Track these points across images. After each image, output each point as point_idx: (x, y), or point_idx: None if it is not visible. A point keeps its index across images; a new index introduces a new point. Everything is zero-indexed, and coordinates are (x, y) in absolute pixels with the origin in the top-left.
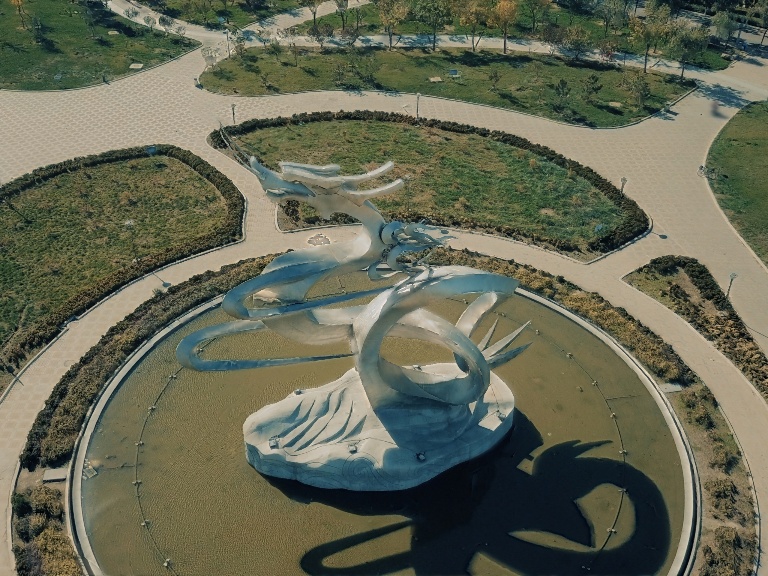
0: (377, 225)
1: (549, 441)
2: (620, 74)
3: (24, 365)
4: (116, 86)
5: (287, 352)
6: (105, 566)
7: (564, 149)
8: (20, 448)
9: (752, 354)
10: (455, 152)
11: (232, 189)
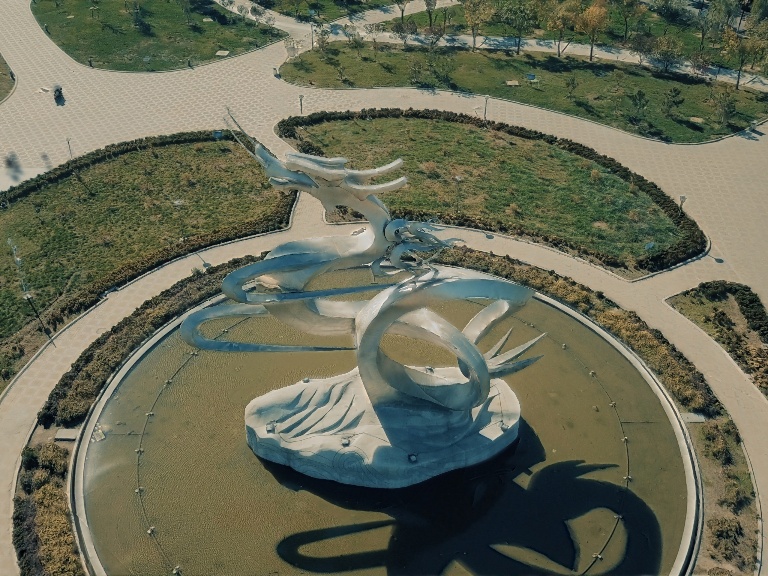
0: (382, 221)
1: (552, 458)
2: (709, 89)
3: (60, 328)
4: (199, 71)
5: (309, 341)
6: (94, 526)
7: (632, 162)
8: (41, 406)
9: None
10: (517, 157)
11: None
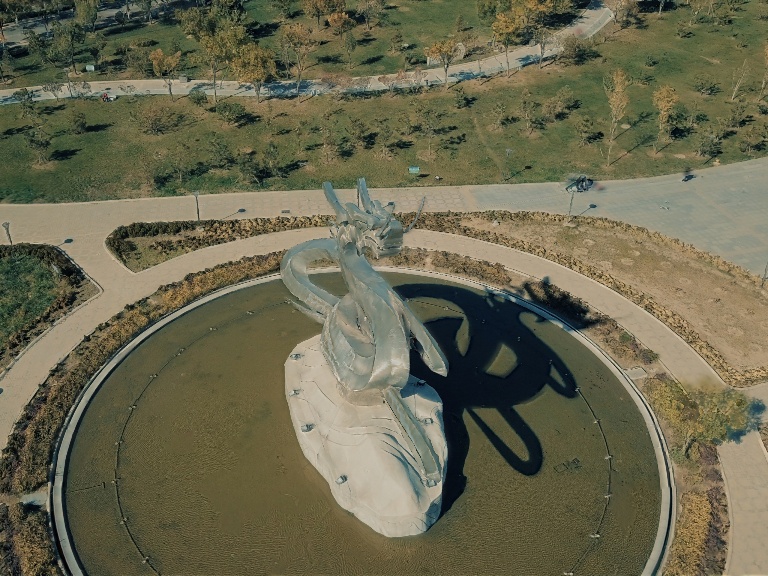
0: None
1: None
2: None
3: None
4: None
5: None
6: None
7: None
8: None
9: (257, 223)
10: None
11: None
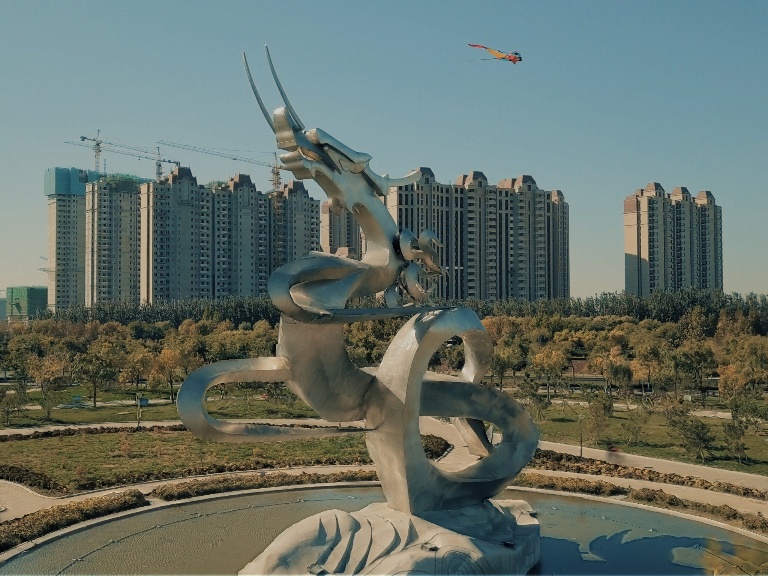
0: (389, 235)
1: (581, 541)
2: None
3: None
4: None
5: (180, 569)
6: None
7: None
8: None
9: (641, 471)
10: None
11: None
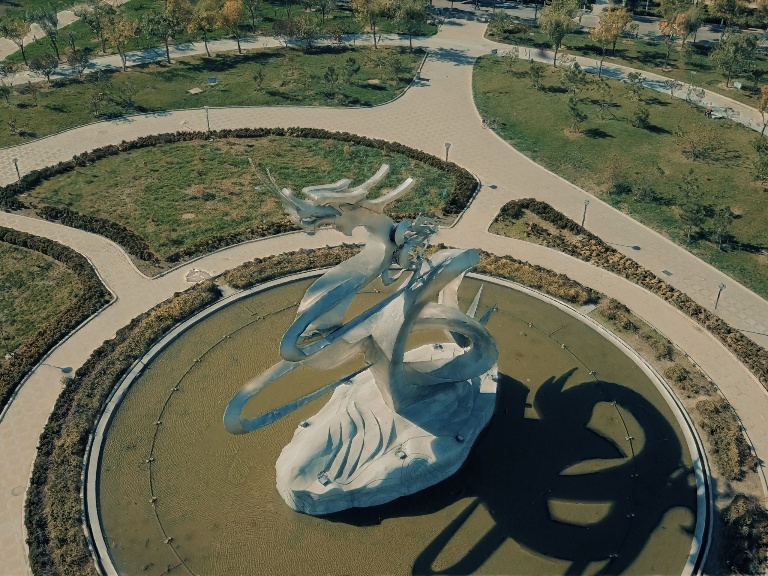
0: (386, 229)
1: (533, 386)
2: (358, 54)
3: None
4: None
5: None
6: None
7: (360, 131)
8: None
9: (624, 262)
10: (267, 156)
11: (65, 250)
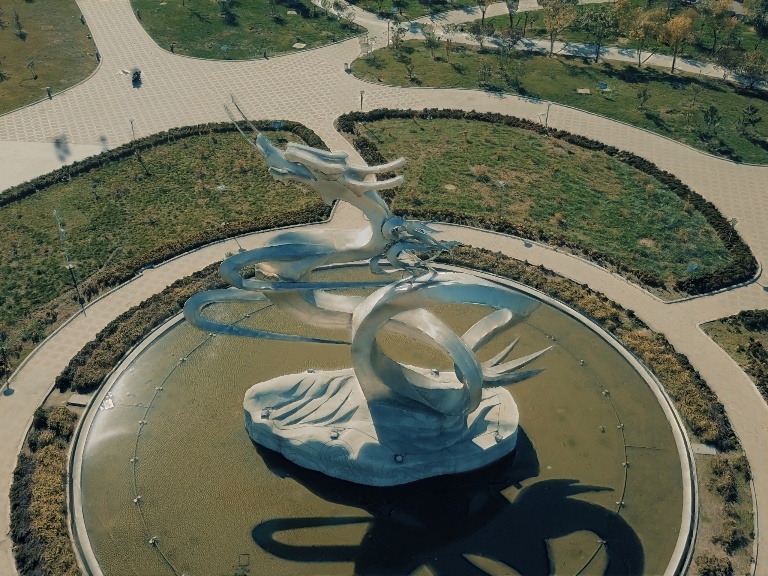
0: (381, 219)
1: (545, 474)
2: None
3: (94, 299)
4: (273, 62)
5: (327, 333)
6: (86, 489)
7: (694, 180)
8: (61, 370)
9: None
10: (572, 167)
11: None
